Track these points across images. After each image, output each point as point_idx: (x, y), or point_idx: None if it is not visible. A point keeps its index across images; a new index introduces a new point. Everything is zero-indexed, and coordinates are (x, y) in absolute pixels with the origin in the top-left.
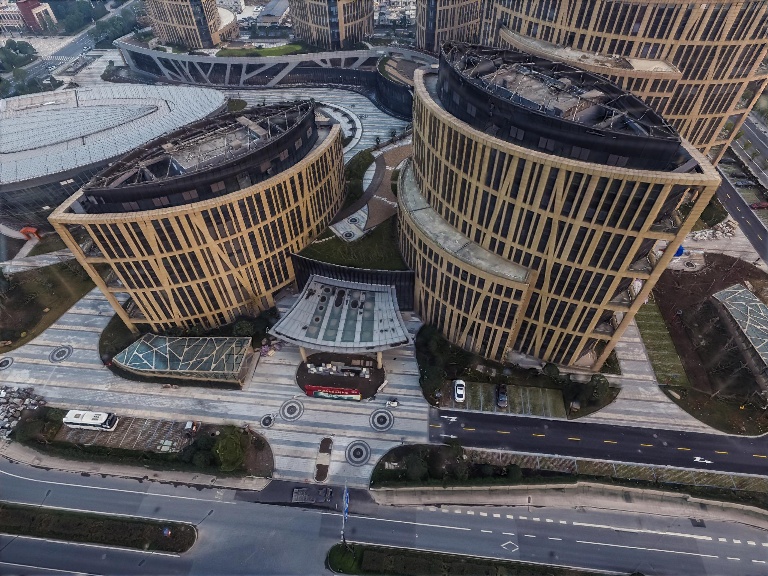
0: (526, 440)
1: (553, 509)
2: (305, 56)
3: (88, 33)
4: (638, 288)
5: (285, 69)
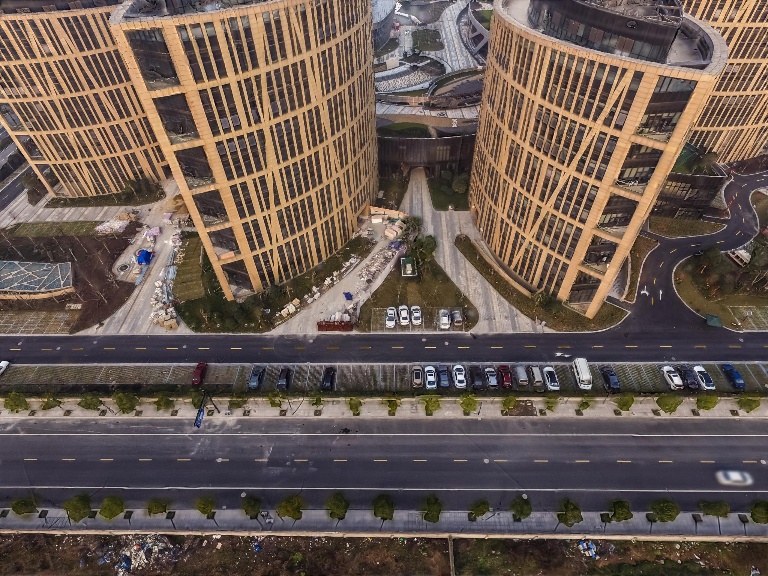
0: (32, 169)
1: None
2: None
3: None
4: (111, 225)
5: (482, 42)
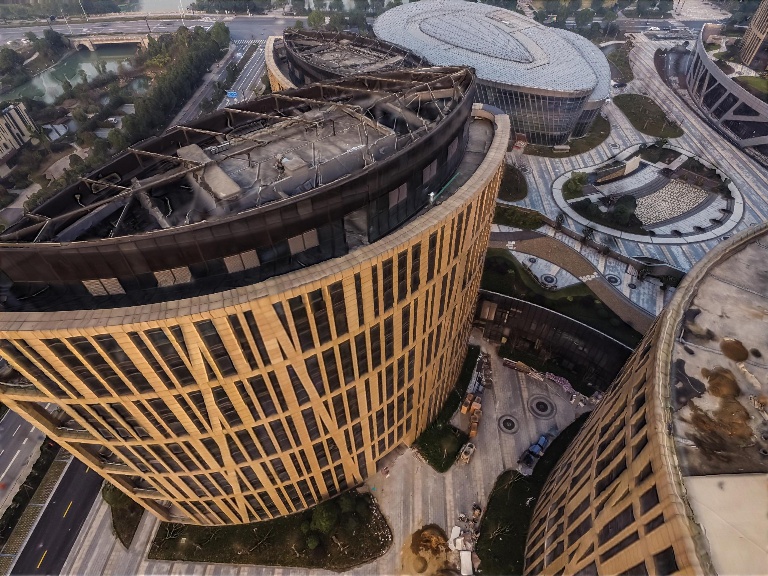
0: None
1: (41, 434)
2: None
3: (733, 15)
4: None
5: None
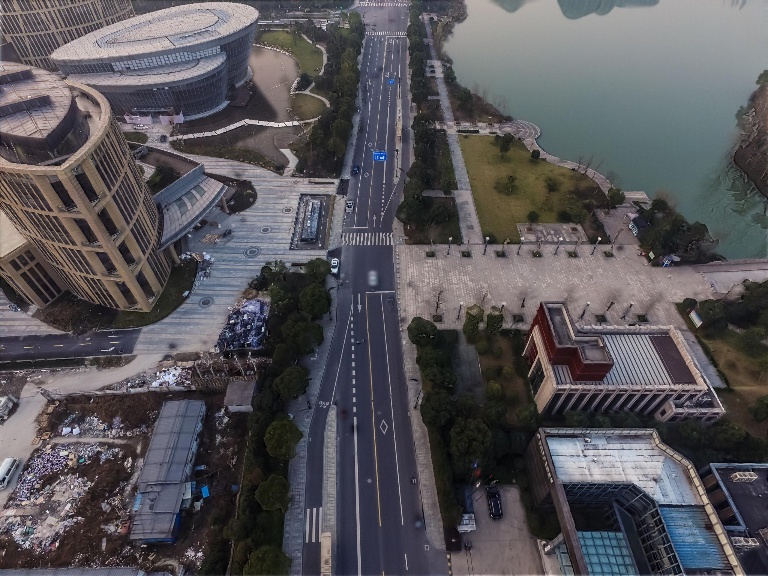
0: None
1: None
2: None
3: None
4: None
5: None
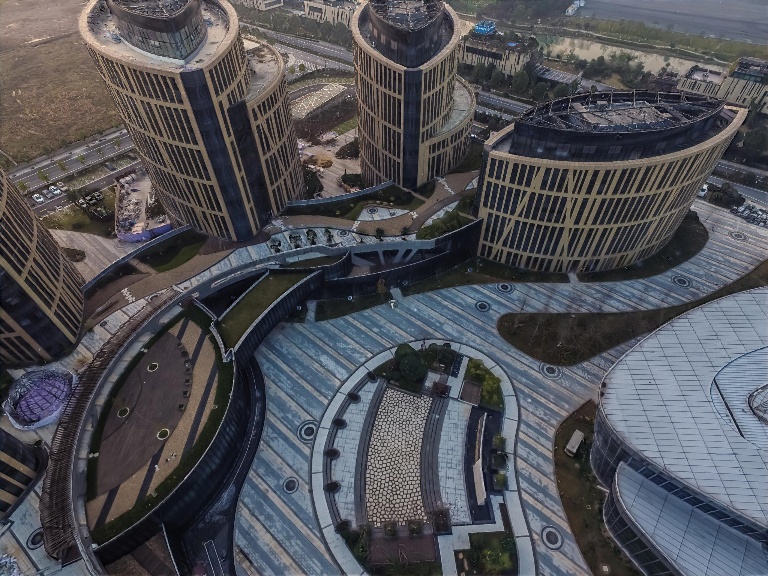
0: None
1: None
2: None
3: None
4: (328, 135)
5: None
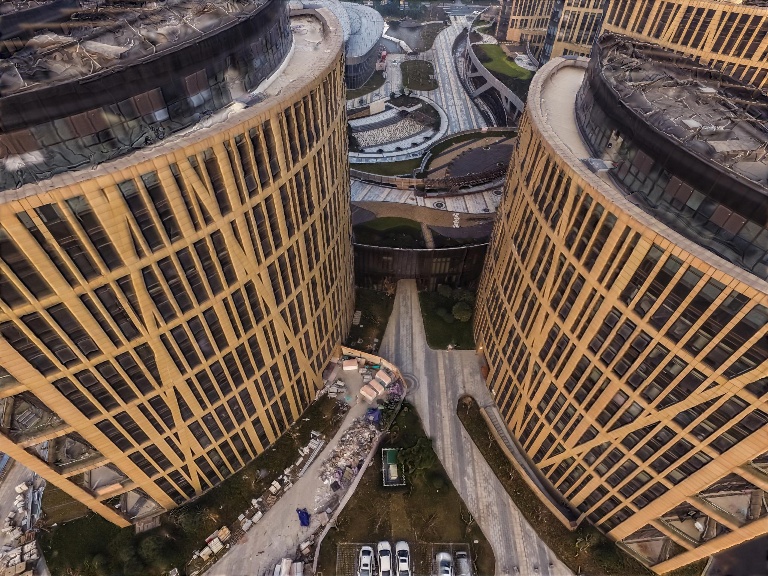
0: None
1: None
2: (497, 82)
3: None
4: None
5: (484, 86)
